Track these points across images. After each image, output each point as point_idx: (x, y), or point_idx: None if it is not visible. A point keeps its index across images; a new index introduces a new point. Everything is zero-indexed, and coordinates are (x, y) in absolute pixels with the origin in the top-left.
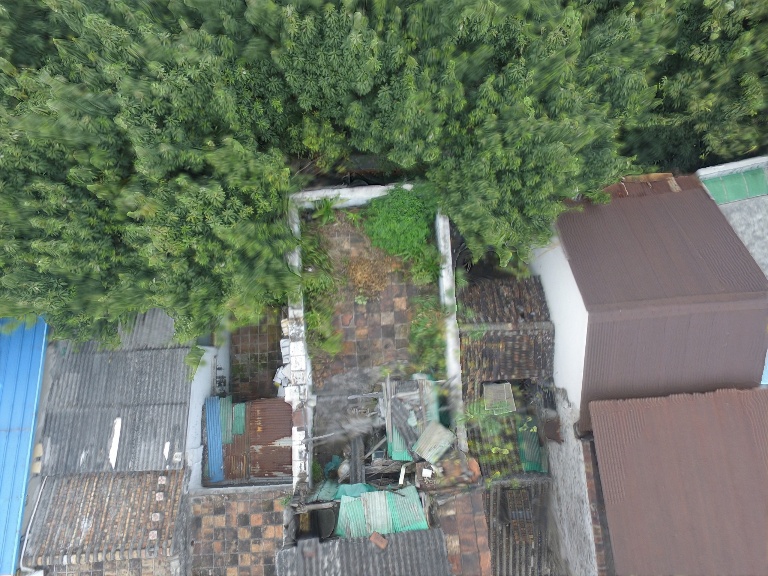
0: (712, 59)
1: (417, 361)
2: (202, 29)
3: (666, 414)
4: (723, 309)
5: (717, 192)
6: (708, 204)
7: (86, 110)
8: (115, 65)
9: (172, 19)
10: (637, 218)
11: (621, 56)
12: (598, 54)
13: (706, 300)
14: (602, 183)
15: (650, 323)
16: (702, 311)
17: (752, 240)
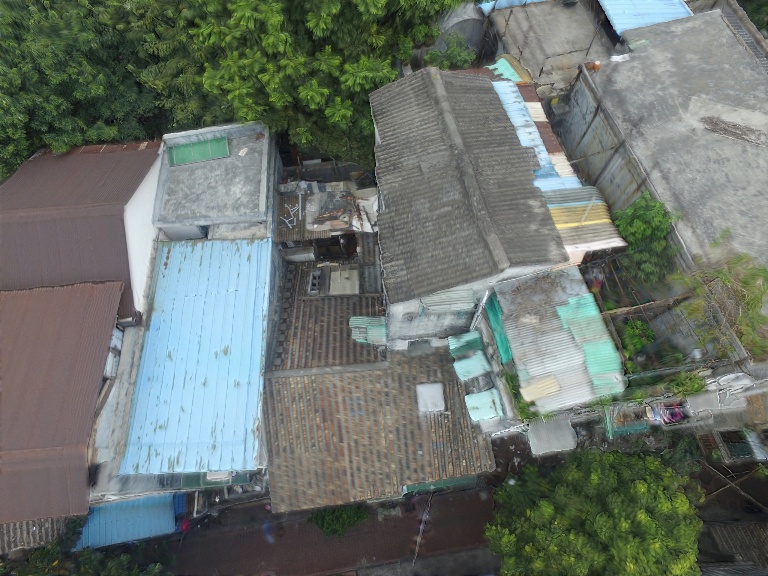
0: (164, 53)
1: None
2: None
3: (20, 302)
4: (79, 215)
5: (186, 154)
6: (152, 156)
7: None
8: None
9: None
10: (87, 165)
11: (55, 40)
12: (31, 37)
13: (66, 208)
14: (7, 123)
15: (21, 227)
16: (62, 217)
17: (205, 190)
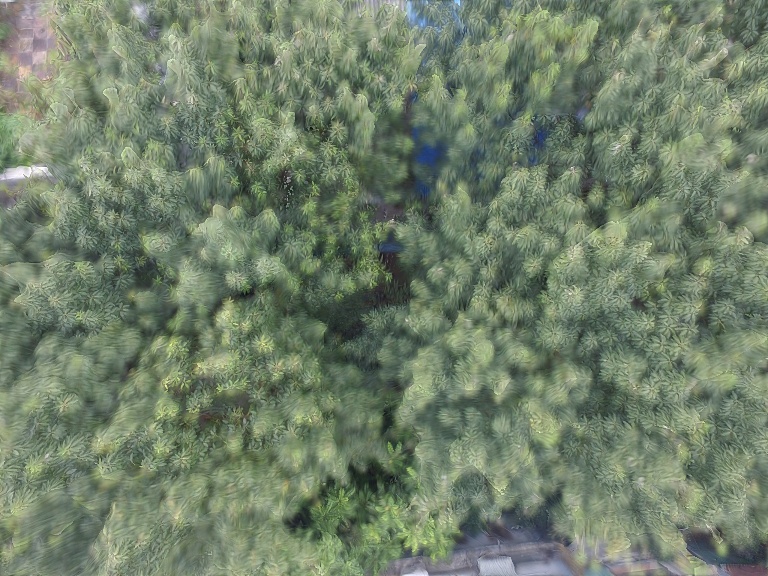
0: None
1: (5, 11)
2: (105, 262)
3: None
4: None
5: None
6: None
7: (176, 79)
8: (153, 147)
9: (172, 302)
10: None
11: None
12: None
13: None
14: None
15: None
16: None
17: None
